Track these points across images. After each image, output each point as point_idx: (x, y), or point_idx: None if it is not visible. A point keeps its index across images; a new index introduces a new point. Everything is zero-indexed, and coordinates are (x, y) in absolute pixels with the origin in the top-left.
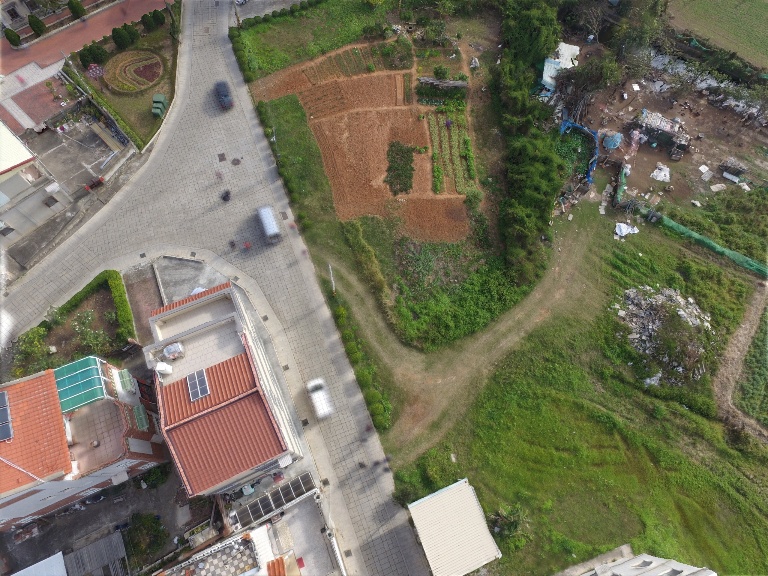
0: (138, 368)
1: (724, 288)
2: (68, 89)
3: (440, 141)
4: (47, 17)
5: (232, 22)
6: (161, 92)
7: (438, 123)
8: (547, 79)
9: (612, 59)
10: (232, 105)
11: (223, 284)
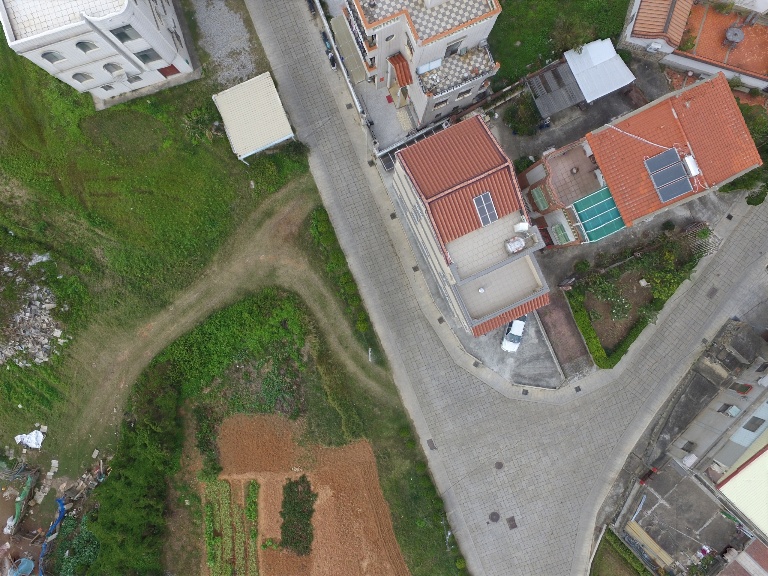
0: (558, 265)
1: None
2: None
3: (246, 559)
4: None
5: None
6: None
7: None
8: None
9: None
10: None
11: None
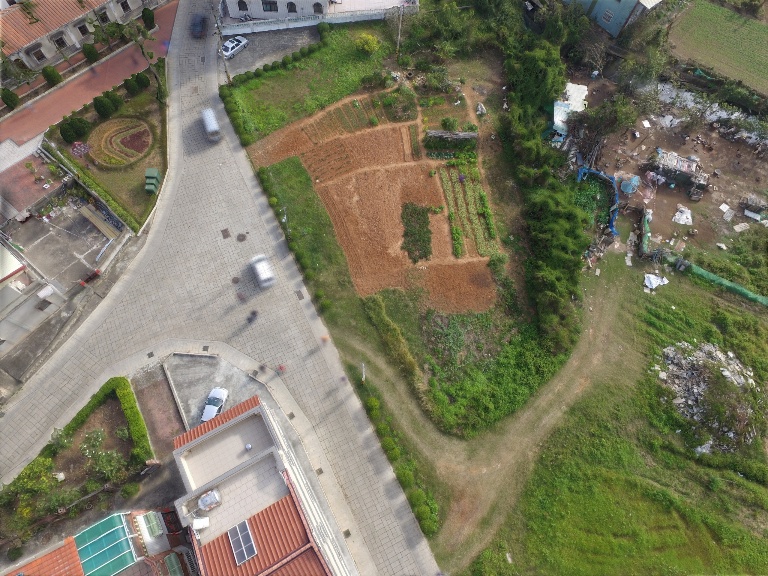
0: (158, 490)
1: (762, 338)
2: (51, 169)
3: (455, 198)
4: (19, 86)
5: (221, 79)
6: (152, 164)
7: (451, 178)
8: (558, 124)
9: (620, 96)
10: (231, 173)
11: (250, 399)
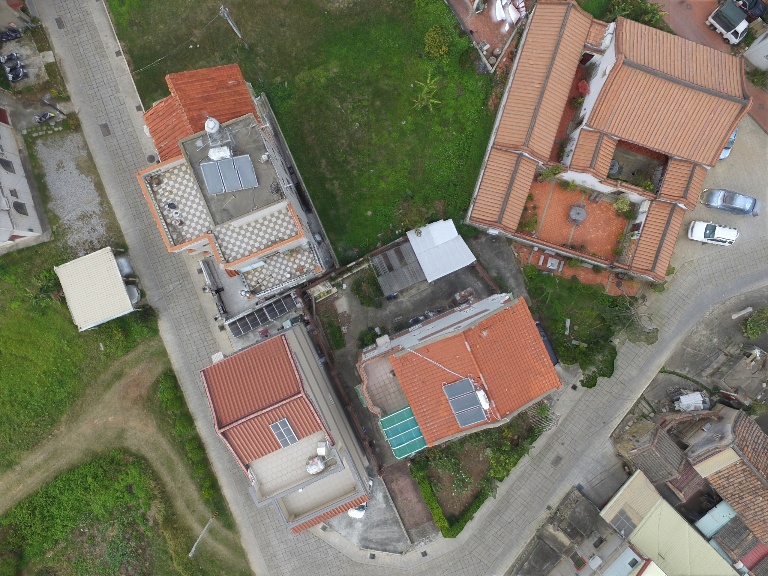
0: None
1: None
2: None
3: None
4: None
5: None
6: None
7: None
8: None
9: None
10: None
11: None
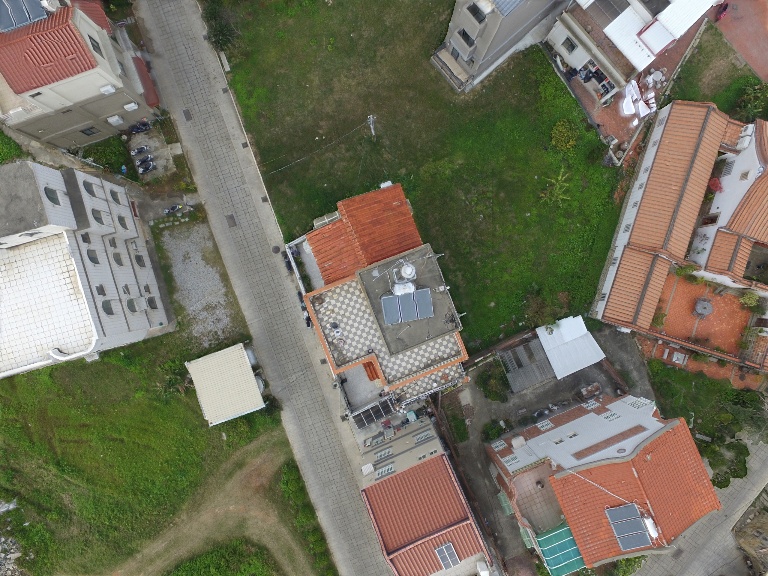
0: None
1: None
2: None
3: None
4: None
5: None
6: None
7: None
8: None
9: None
10: None
11: None
